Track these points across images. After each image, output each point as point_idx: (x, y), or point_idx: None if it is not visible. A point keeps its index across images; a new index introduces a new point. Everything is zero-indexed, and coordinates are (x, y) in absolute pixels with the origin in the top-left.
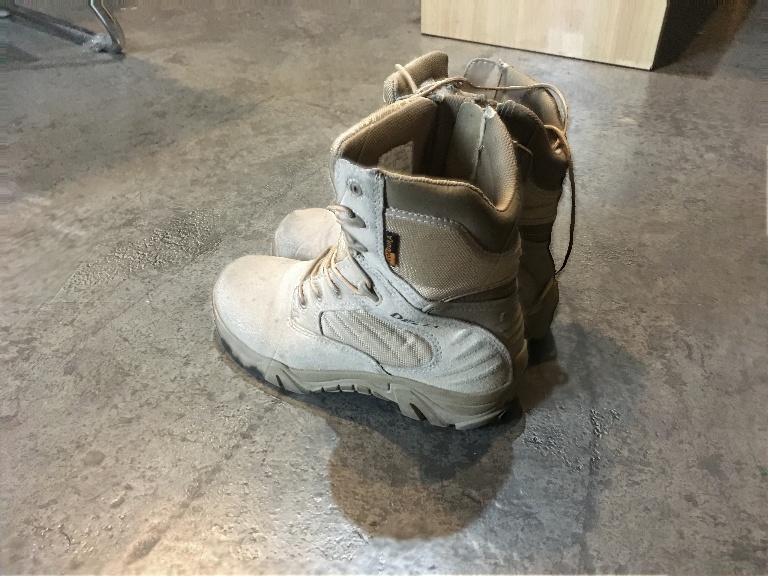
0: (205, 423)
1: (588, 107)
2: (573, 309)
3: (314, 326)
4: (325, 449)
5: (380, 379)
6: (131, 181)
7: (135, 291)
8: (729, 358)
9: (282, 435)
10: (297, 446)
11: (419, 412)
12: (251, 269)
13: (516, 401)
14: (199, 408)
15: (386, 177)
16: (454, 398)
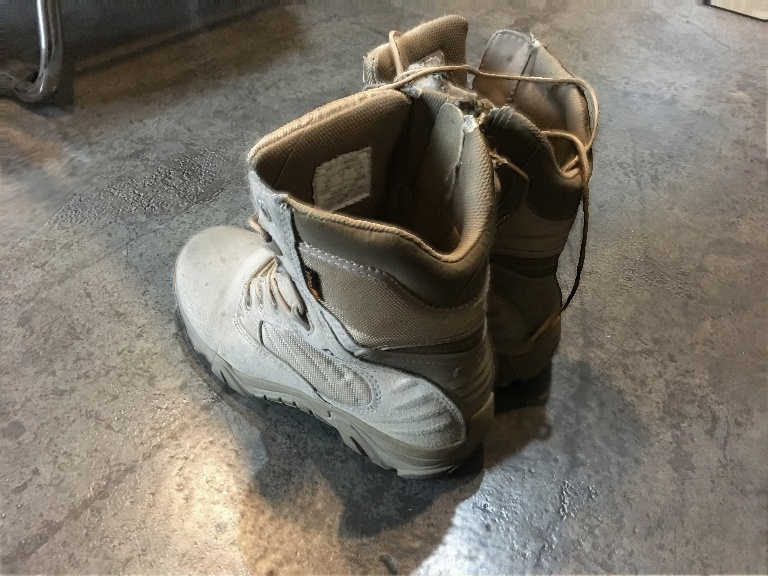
0: (135, 411)
1: (696, 71)
2: (587, 342)
3: (255, 333)
4: (248, 469)
5: (320, 405)
6: (155, 104)
7: (116, 238)
8: (761, 444)
9: (209, 442)
10: (220, 459)
11: (360, 447)
12: (215, 245)
13: (479, 452)
14: (135, 392)
15: (293, 209)
16: (395, 445)
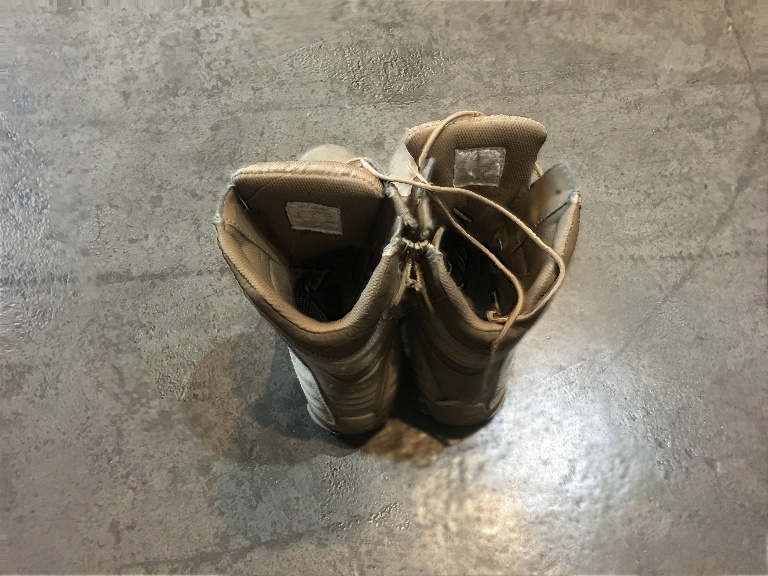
0: None
1: None
2: (532, 434)
3: None
4: (239, 327)
5: None
6: None
7: (314, 97)
8: None
9: (235, 293)
10: (231, 308)
11: None
12: None
13: (368, 436)
14: None
15: None
16: None
